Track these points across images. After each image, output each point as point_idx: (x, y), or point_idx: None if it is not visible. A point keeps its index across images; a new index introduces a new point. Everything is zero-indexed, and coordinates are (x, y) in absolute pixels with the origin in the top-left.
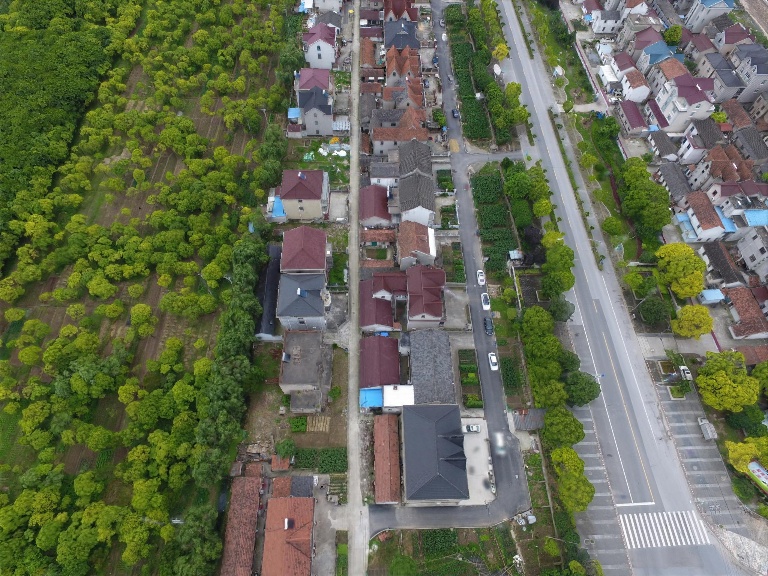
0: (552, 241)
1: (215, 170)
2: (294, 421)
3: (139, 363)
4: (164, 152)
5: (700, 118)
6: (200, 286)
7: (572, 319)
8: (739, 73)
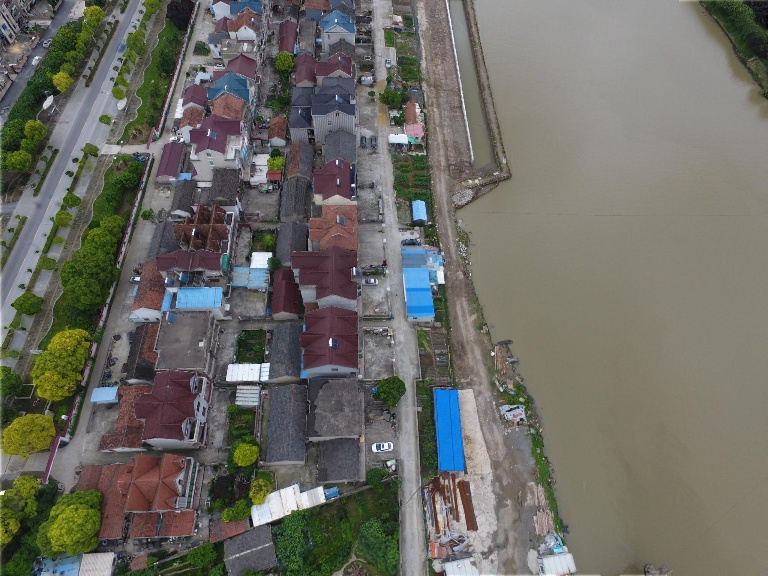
0: None
1: None
2: None
3: None
4: None
5: (226, 167)
6: None
7: None
8: None
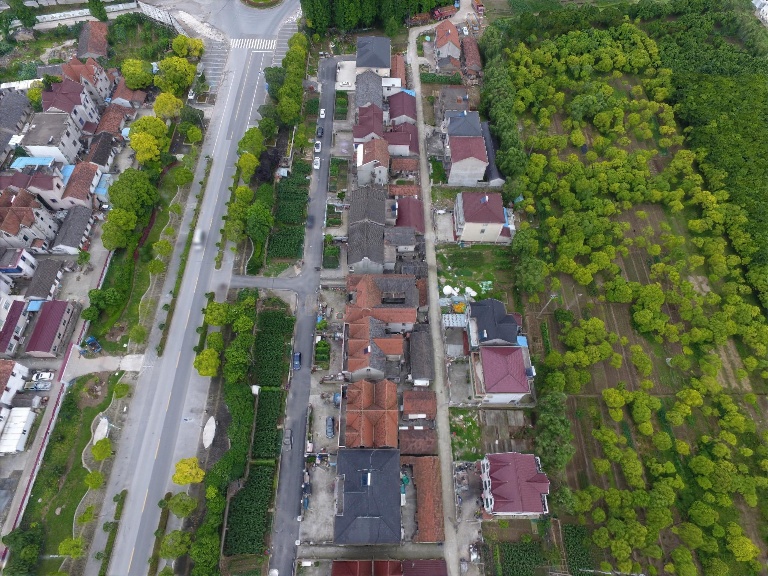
0: None
1: None
2: None
3: None
4: None
5: None
6: None
7: None
8: None
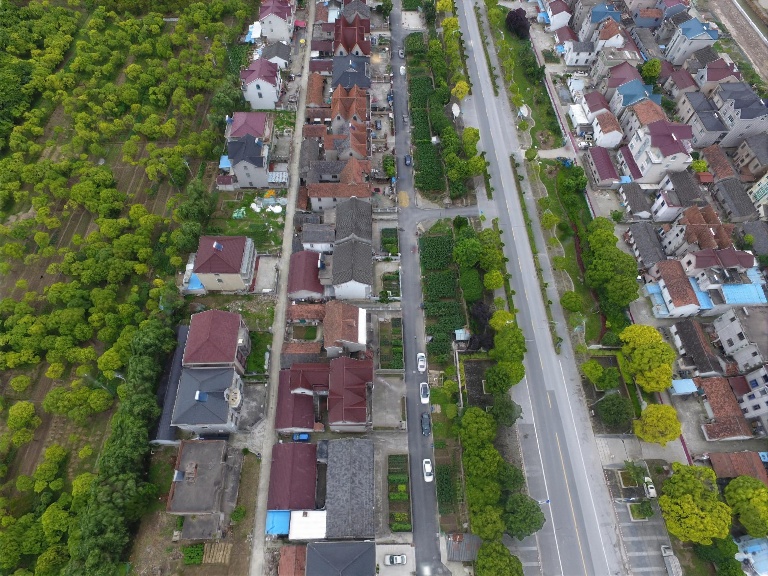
0: (501, 324)
1: (131, 231)
2: (188, 551)
3: (16, 474)
4: (78, 208)
5: (676, 170)
6: (99, 374)
7: (522, 416)
8: (722, 115)
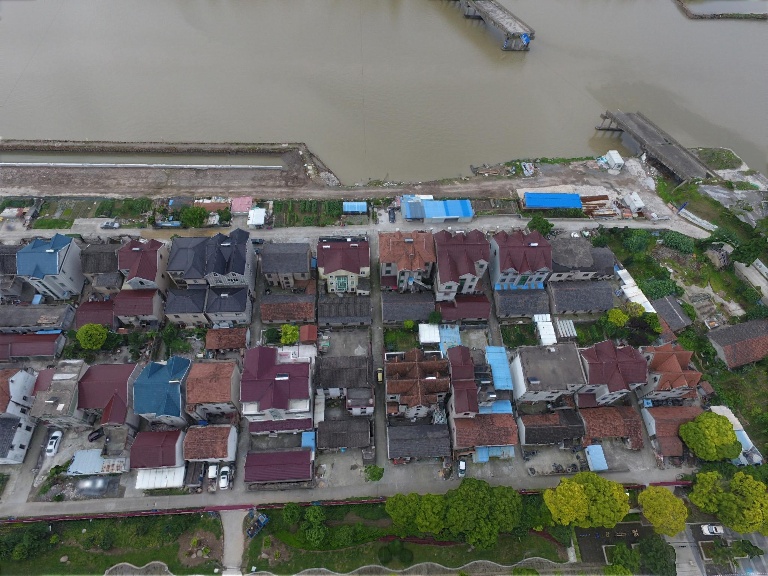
0: None
1: None
2: None
3: None
4: None
5: (311, 375)
6: None
7: None
8: (220, 285)
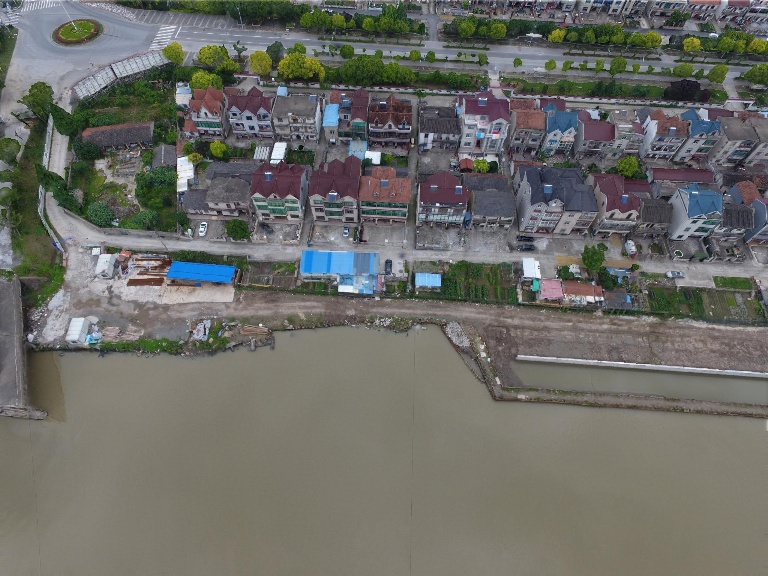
0: None
1: None
2: None
3: None
4: None
5: None
6: None
7: (286, 35)
8: None
